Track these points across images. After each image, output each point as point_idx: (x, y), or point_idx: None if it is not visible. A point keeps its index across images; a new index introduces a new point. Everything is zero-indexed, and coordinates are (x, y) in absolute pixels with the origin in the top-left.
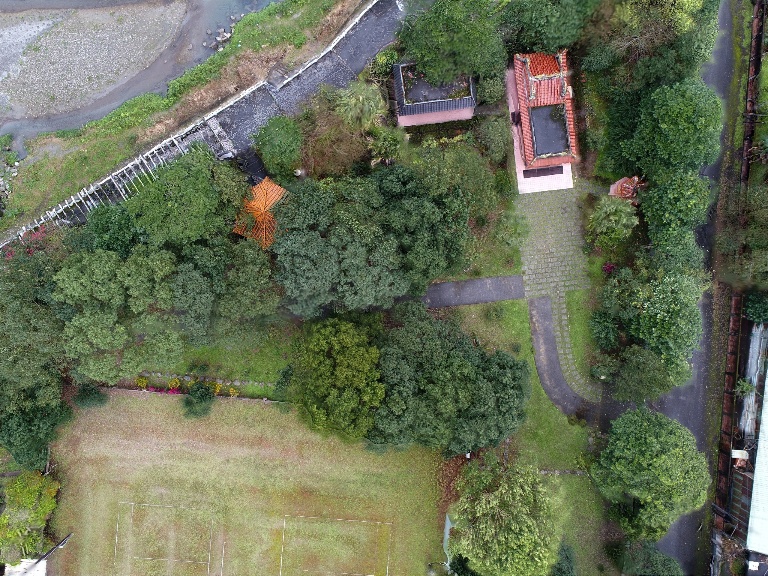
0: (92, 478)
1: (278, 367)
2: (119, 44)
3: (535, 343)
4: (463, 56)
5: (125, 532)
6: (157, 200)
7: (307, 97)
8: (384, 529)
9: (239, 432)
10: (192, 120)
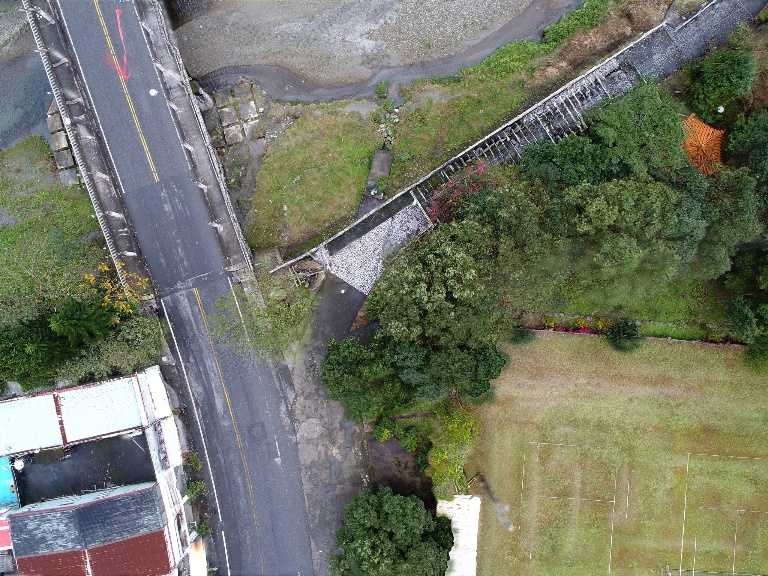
0: (498, 418)
1: (677, 307)
2: None
3: None
4: None
5: (531, 471)
6: (632, 130)
7: (705, 38)
8: None
9: (642, 371)
10: (589, 62)
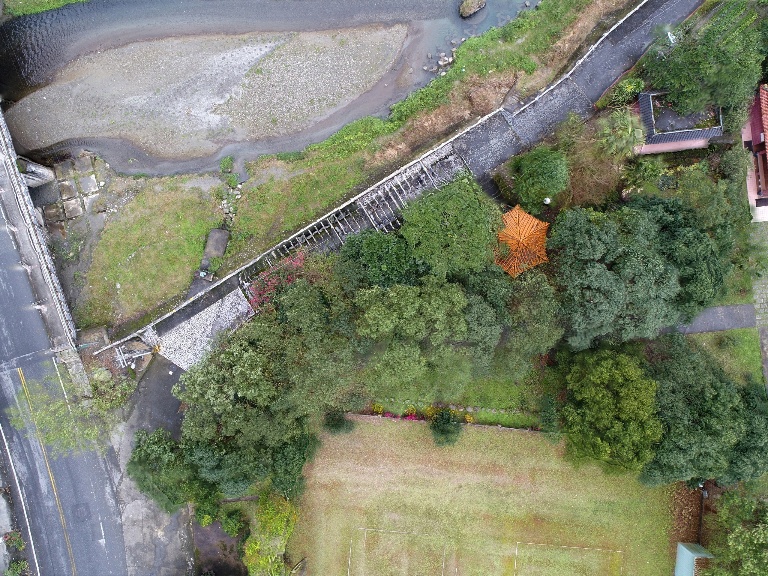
0: (325, 503)
1: (510, 394)
2: (341, 67)
3: (766, 372)
4: (722, 87)
5: (358, 557)
6: (436, 230)
7: (543, 124)
8: (616, 557)
9: (472, 458)
10: (426, 145)
